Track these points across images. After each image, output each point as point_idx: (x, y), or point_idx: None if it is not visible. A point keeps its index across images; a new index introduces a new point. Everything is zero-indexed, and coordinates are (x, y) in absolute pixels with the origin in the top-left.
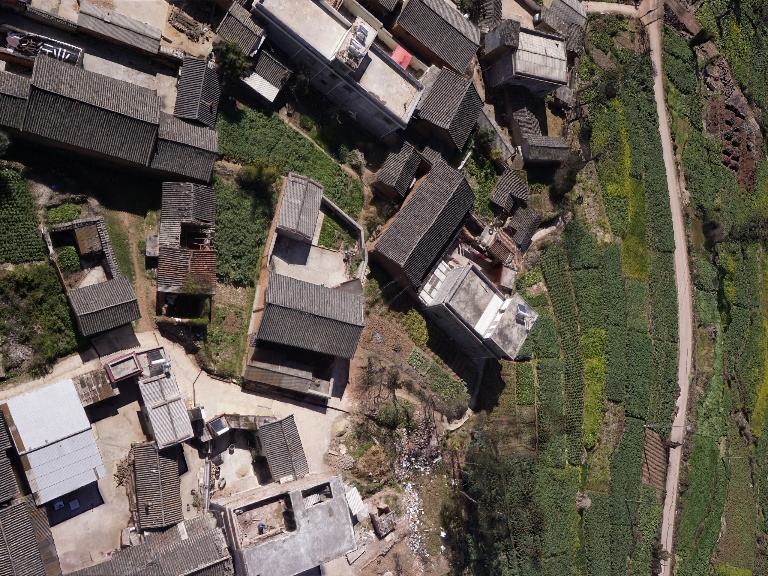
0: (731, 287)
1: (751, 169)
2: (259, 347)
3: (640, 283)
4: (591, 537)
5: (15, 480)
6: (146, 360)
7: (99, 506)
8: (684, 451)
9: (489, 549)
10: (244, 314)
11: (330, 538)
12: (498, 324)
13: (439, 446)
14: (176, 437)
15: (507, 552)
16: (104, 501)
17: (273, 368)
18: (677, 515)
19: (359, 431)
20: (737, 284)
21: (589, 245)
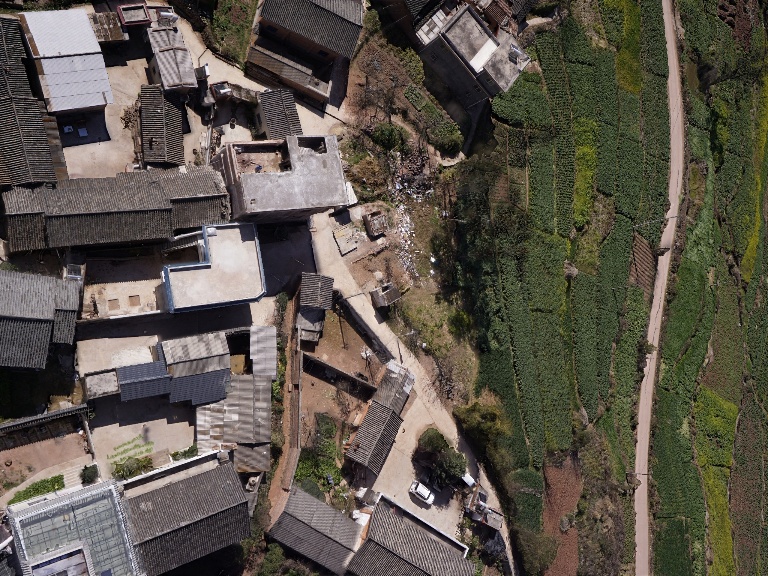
0: (724, 131)
1: (747, 28)
2: (262, 36)
3: (633, 95)
4: (578, 311)
5: (29, 85)
6: (155, 15)
7: (106, 141)
8: (672, 263)
9: (477, 279)
10: (249, 11)
11: (323, 187)
12: (491, 57)
13: (432, 177)
14: (181, 80)
15: (494, 287)
16: (111, 138)
17: (275, 56)
18: (664, 321)
19: (355, 142)
20: (730, 131)
21: (584, 42)
